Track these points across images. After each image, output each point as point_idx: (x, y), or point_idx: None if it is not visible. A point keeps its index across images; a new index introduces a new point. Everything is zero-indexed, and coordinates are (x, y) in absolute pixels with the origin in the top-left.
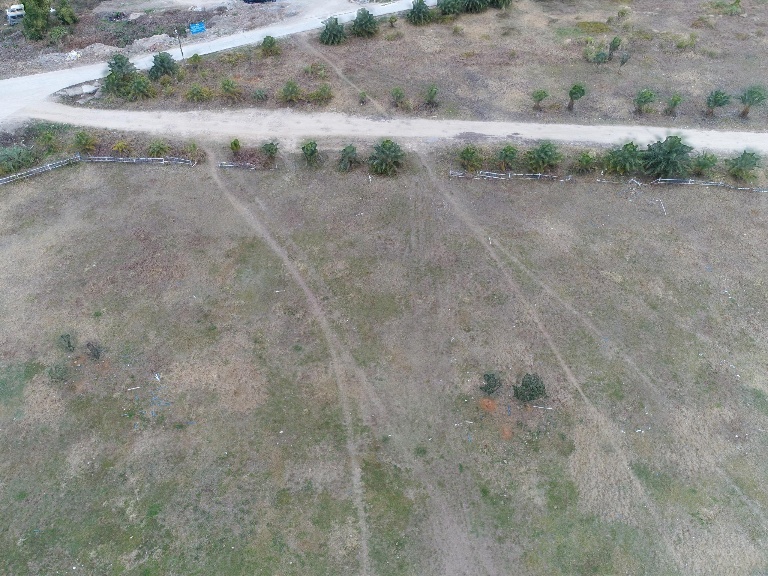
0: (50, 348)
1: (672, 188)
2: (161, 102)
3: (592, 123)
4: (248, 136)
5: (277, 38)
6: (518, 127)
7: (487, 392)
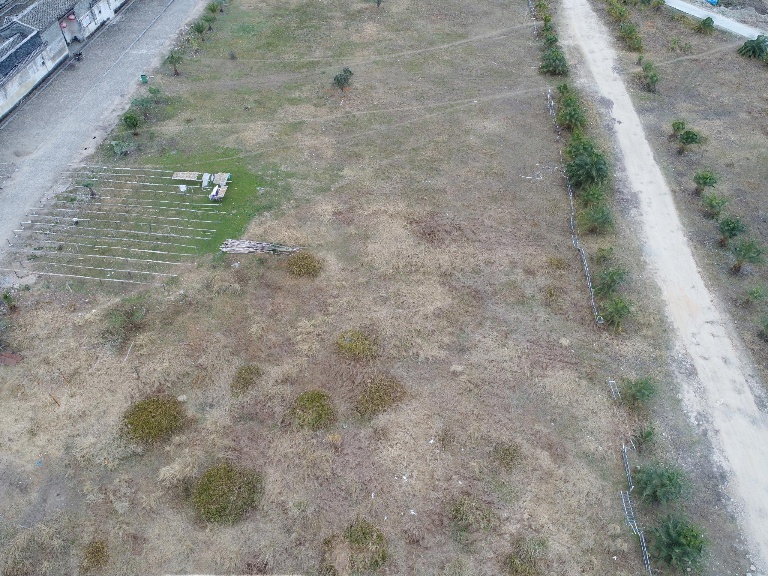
0: (389, 3)
1: (562, 188)
2: (602, 4)
3: (660, 163)
4: (571, 29)
5: (731, 32)
6: (633, 125)
7: None
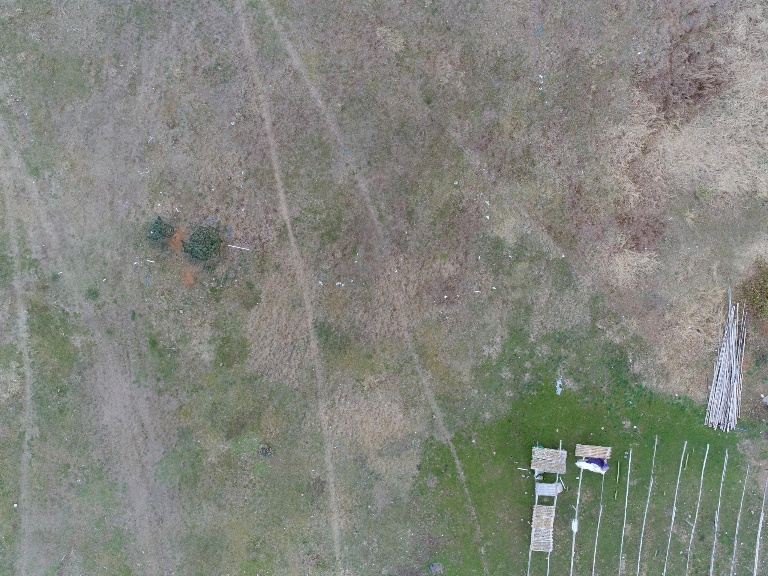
0: None
1: None
2: None
3: None
4: None
5: None
6: None
7: (160, 238)
